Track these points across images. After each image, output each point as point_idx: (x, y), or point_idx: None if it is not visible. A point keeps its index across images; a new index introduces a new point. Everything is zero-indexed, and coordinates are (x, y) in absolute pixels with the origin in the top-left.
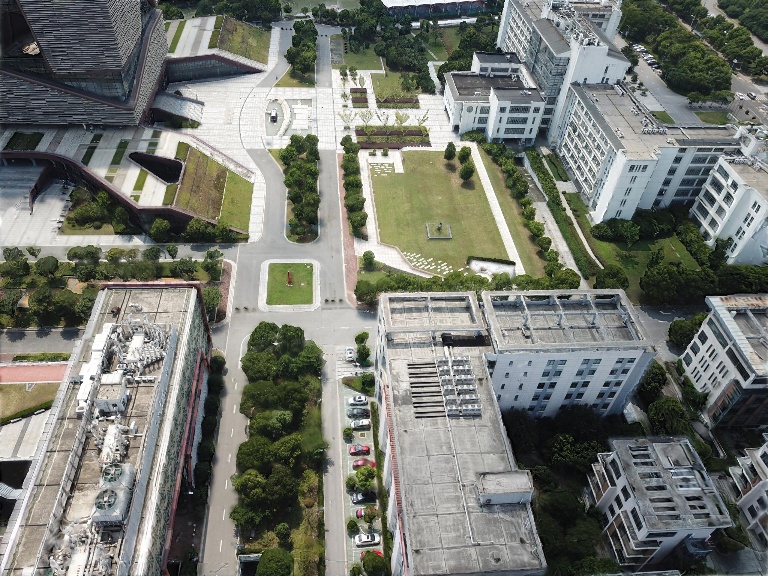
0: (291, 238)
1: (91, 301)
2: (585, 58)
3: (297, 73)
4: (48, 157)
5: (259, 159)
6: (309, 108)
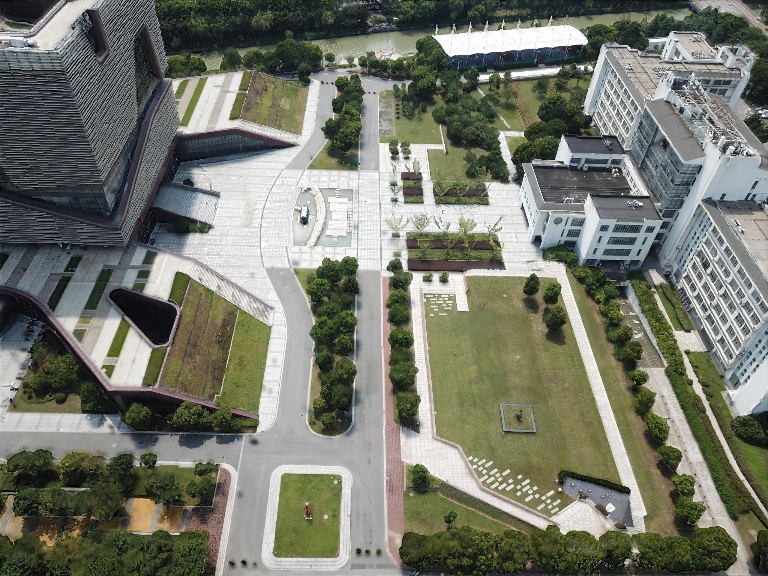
0: (315, 426)
1: (20, 568)
2: (727, 170)
3: (337, 149)
4: (8, 293)
5: (281, 285)
6: (349, 202)
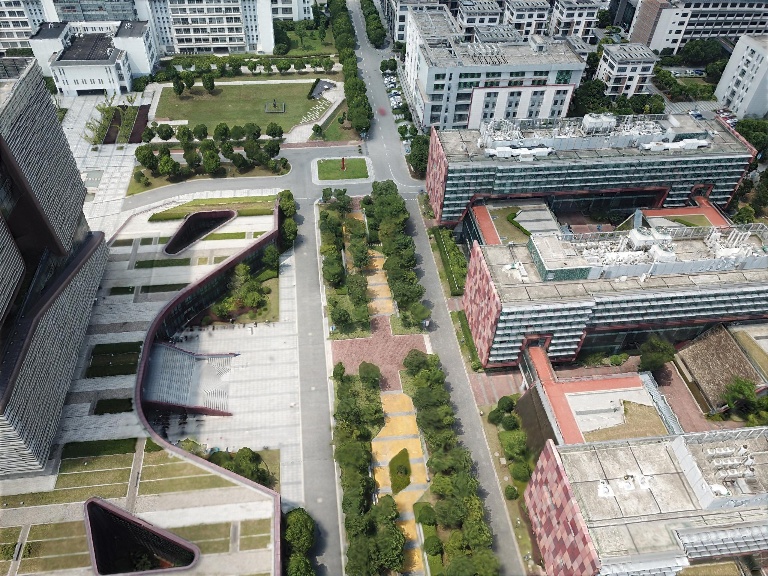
0: (284, 172)
1: None
2: None
3: None
4: (156, 329)
5: (146, 201)
6: None
